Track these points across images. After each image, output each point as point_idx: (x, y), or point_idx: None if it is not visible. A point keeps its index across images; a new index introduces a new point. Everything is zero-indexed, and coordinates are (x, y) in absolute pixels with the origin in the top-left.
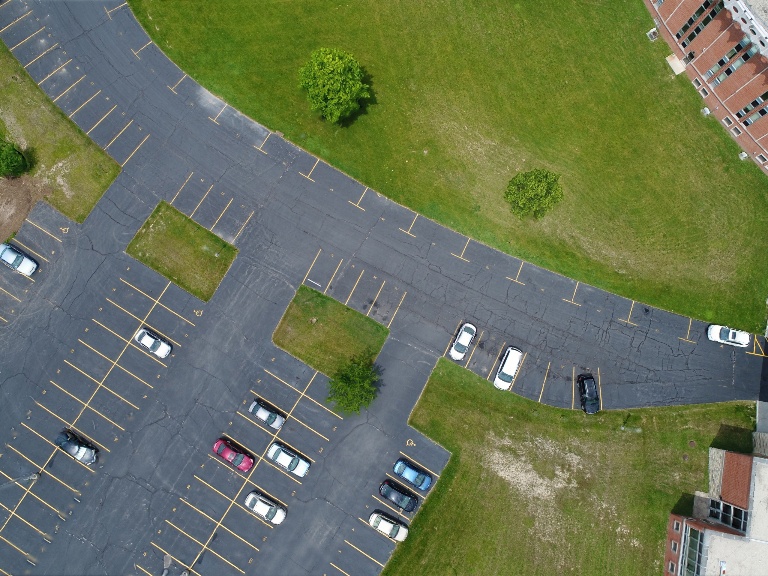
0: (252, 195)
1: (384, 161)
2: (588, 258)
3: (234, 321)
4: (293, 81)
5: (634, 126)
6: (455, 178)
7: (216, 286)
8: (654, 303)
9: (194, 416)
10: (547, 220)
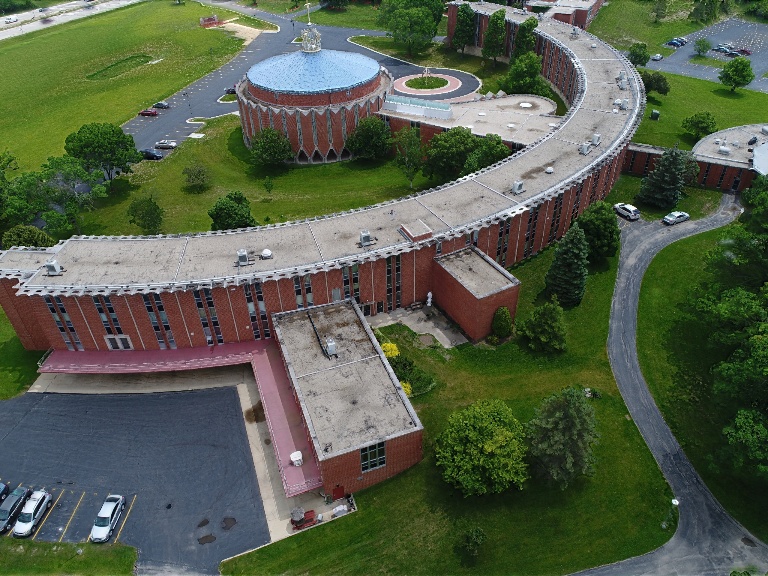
0: (761, 83)
1: None
2: None
3: (755, 68)
4: (755, 98)
5: None
6: (667, 77)
7: (767, 73)
8: None
9: (762, 59)
10: None
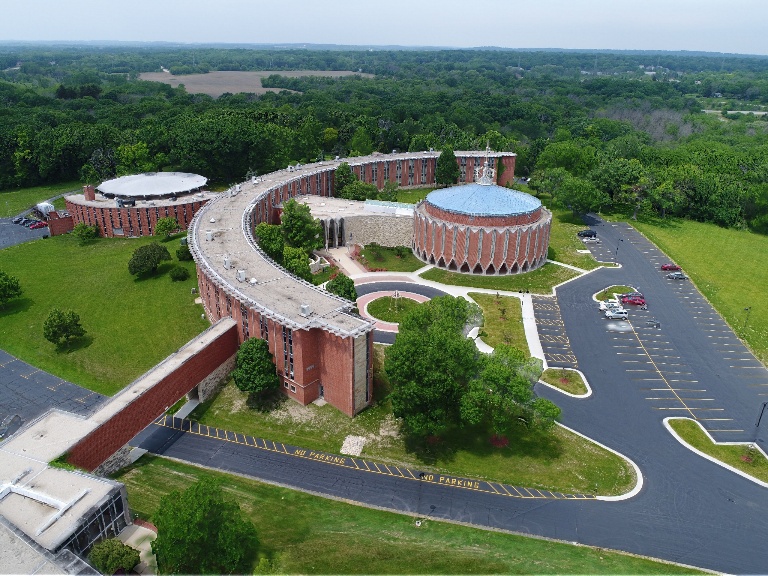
0: None
1: (4, 329)
2: (83, 371)
3: None
4: None
5: (157, 320)
6: None
7: None
8: (107, 394)
9: None
10: (73, 354)
